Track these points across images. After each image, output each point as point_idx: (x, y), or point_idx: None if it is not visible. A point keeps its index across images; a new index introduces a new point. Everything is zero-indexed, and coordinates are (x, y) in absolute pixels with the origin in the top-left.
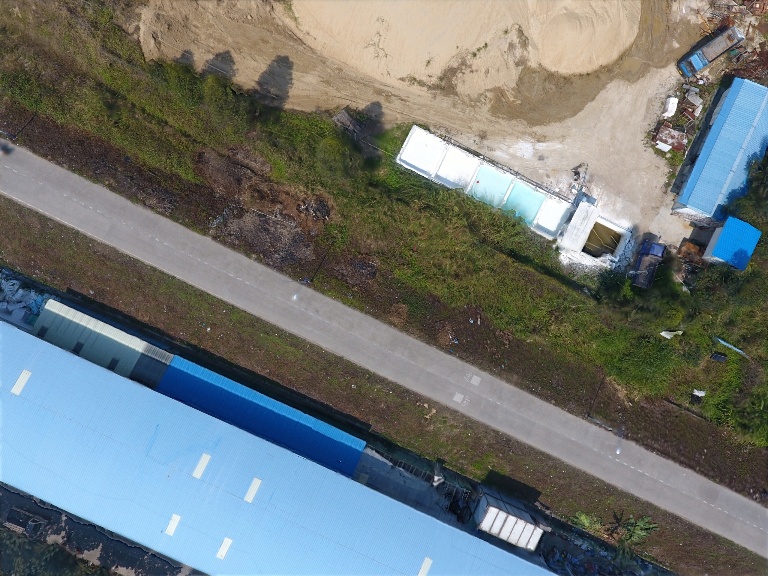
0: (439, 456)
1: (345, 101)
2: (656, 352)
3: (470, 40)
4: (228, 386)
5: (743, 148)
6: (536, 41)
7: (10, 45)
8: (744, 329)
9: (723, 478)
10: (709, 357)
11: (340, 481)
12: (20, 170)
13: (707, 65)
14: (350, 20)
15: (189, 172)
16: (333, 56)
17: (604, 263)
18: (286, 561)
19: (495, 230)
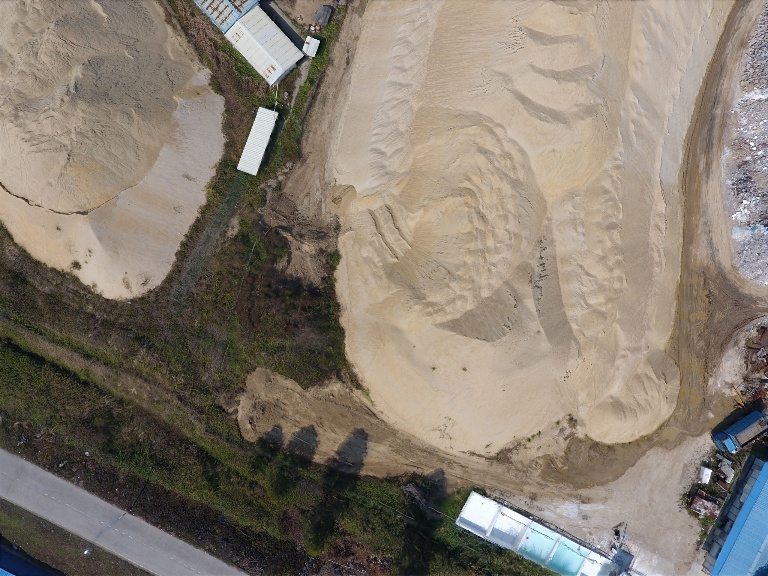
0: None
1: (412, 468)
2: None
3: (526, 431)
4: None
5: None
6: (584, 418)
7: (127, 419)
8: None
9: None
10: None
11: None
12: (135, 536)
13: None
14: (421, 413)
15: (275, 531)
16: (403, 430)
17: None
18: None
19: None
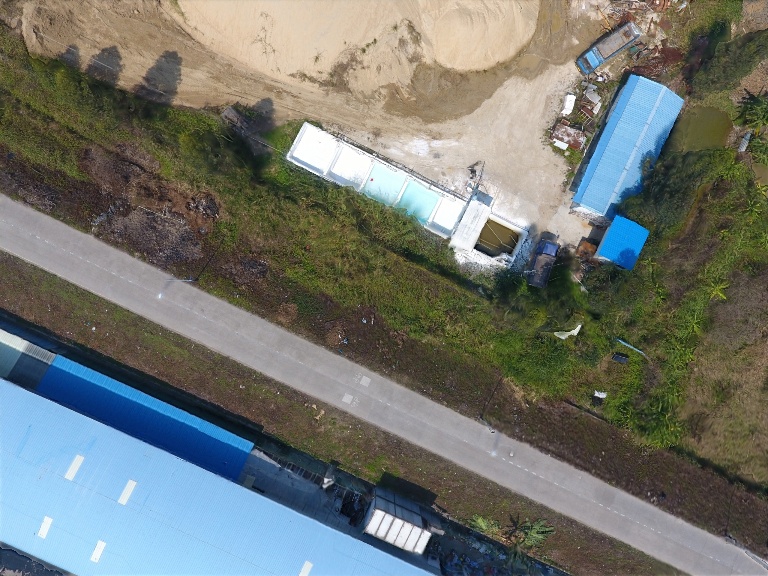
0: (333, 458)
1: (235, 97)
2: (550, 353)
3: (358, 36)
4: (112, 386)
5: (637, 146)
6: (430, 37)
7: None
8: (645, 330)
9: (619, 481)
10: (611, 358)
11: (219, 483)
12: None
13: (607, 62)
14: (235, 15)
15: (74, 169)
16: (222, 52)
17: (500, 262)
18: (161, 564)
19: (386, 229)
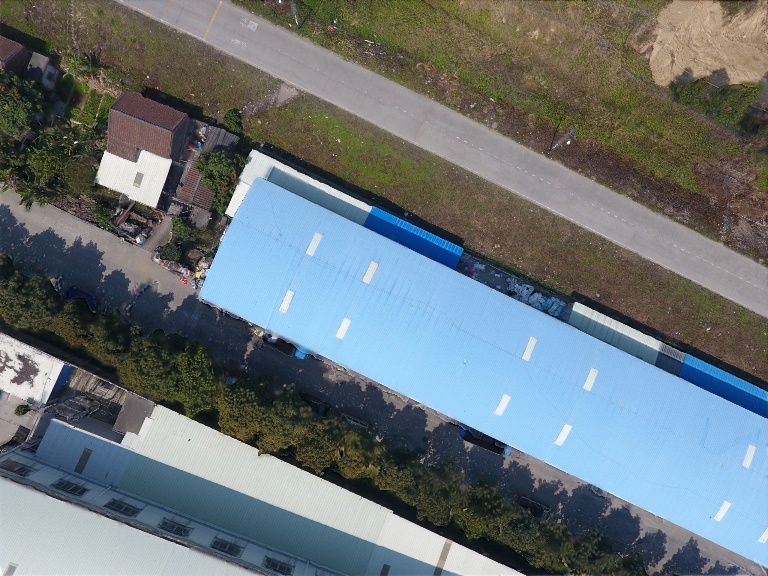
0: None
1: None
2: None
3: None
4: (734, 382)
5: None
6: None
7: (529, 65)
8: None
9: None
10: None
11: None
12: (553, 182)
13: None
14: None
15: (691, 182)
16: None
17: None
18: None
19: None
